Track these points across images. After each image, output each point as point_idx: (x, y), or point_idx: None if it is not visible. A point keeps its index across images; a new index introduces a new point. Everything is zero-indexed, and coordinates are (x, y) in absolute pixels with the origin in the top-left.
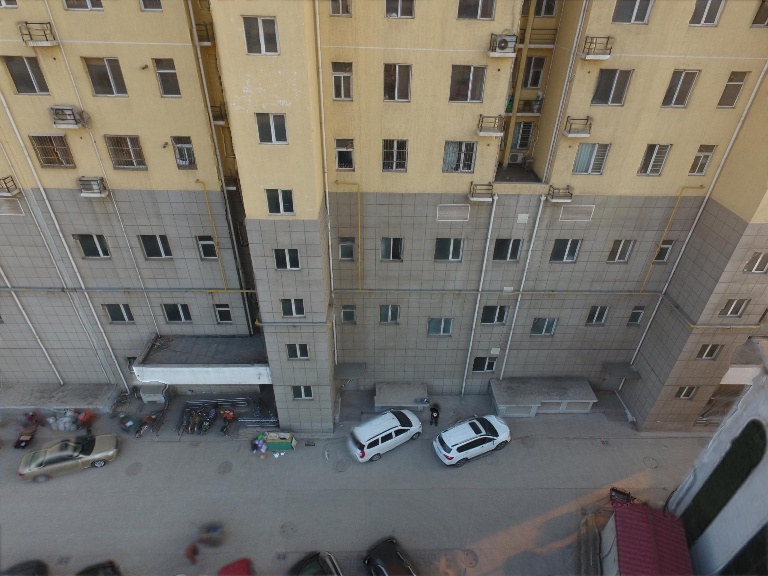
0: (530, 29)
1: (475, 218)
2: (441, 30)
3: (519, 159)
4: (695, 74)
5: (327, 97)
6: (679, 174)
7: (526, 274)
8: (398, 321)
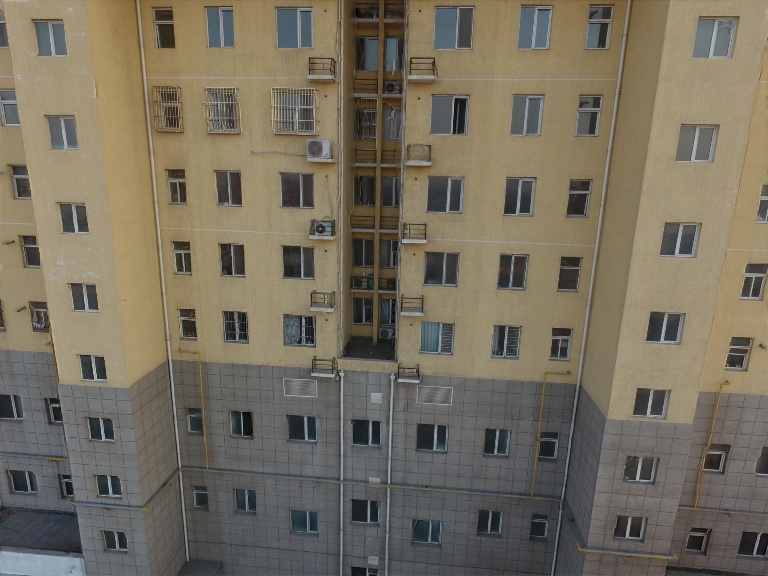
0: (378, 217)
1: (324, 395)
2: (267, 216)
3: (390, 335)
4: (525, 258)
5: (168, 271)
6: (539, 358)
7: (392, 463)
8: (256, 510)
